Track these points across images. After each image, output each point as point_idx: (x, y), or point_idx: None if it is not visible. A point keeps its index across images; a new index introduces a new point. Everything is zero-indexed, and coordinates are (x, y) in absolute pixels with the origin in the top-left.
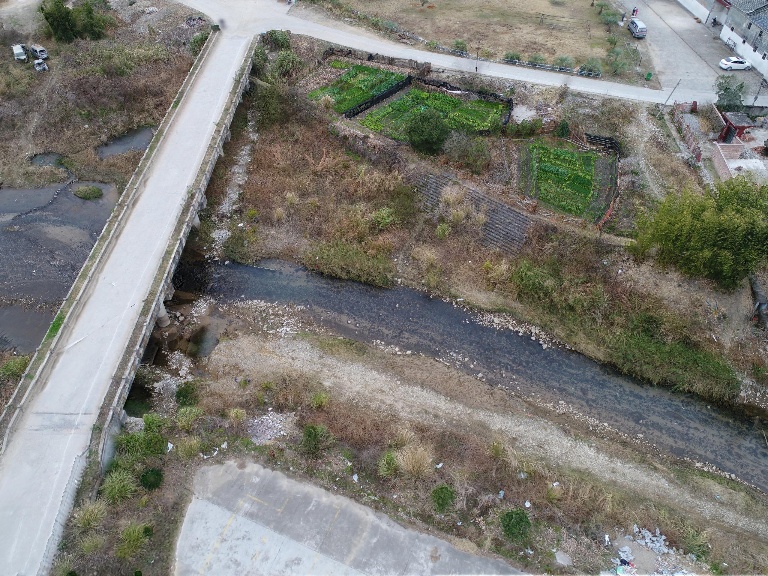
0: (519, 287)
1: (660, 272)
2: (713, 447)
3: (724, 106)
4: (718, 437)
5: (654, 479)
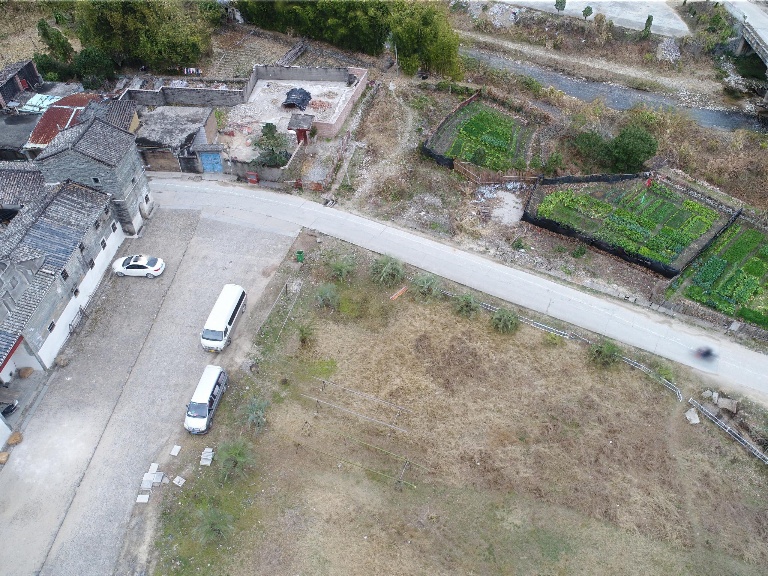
0: None
1: None
2: None
3: None
4: None
5: None
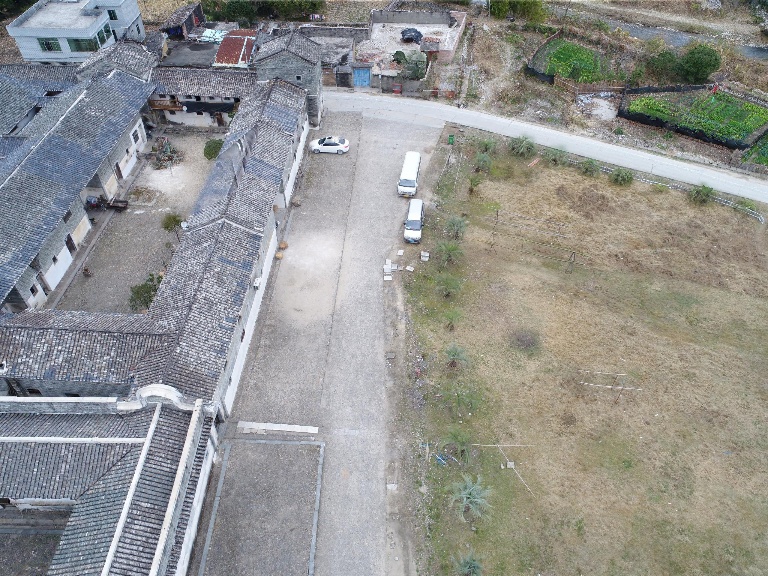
0: None
1: None
2: None
3: None
4: None
5: None
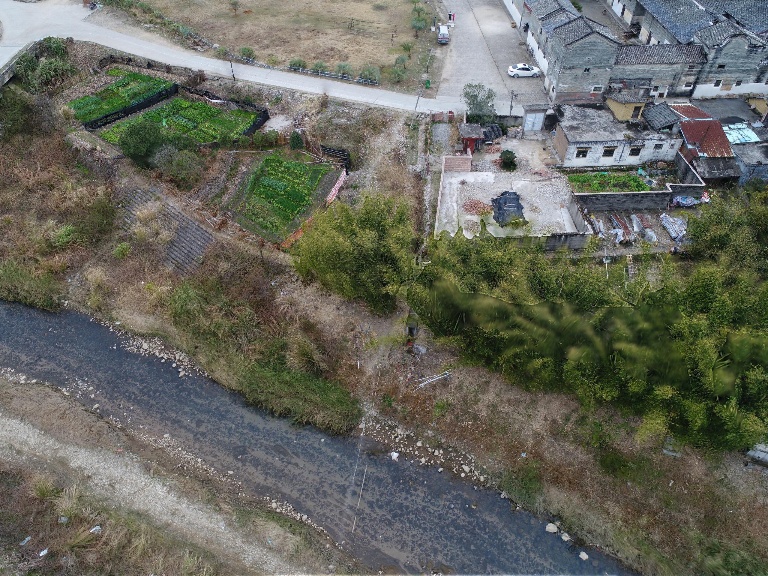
0: (174, 310)
1: (323, 294)
2: (303, 485)
3: (474, 116)
4: (314, 474)
5: (213, 522)
